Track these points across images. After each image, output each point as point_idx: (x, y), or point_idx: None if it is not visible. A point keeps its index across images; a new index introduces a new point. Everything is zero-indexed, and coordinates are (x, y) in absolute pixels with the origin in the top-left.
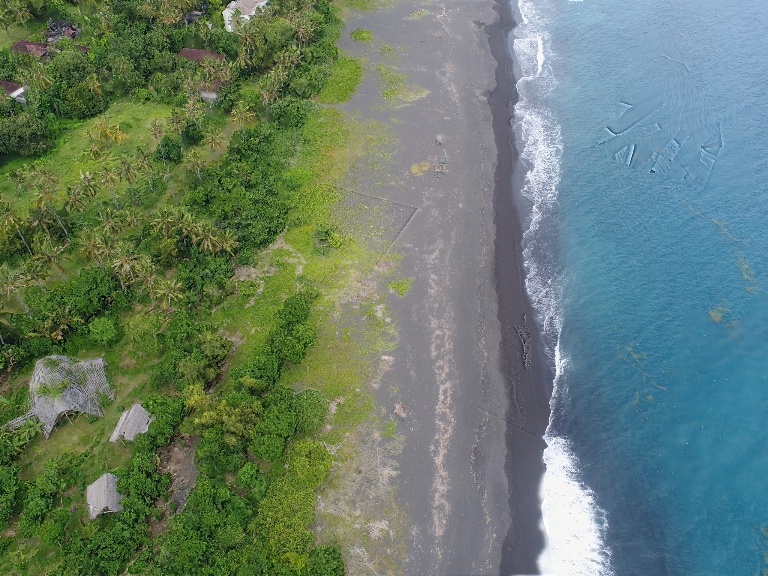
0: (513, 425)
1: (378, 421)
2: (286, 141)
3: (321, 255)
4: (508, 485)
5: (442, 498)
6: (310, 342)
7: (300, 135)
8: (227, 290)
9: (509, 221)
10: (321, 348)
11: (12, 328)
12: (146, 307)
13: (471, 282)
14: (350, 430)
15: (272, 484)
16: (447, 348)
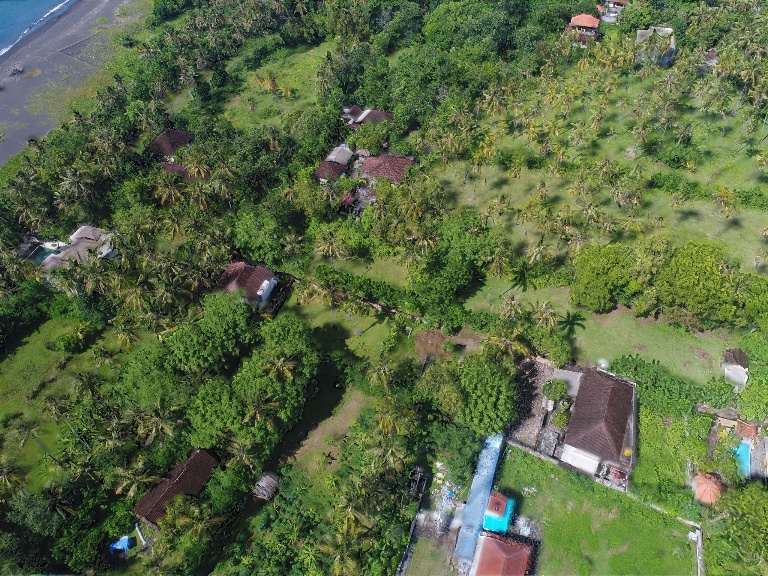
0: None
1: None
2: None
3: None
4: None
5: None
6: None
7: None
8: None
9: (5, 56)
10: None
11: None
12: None
13: None
14: None
15: None
16: (96, 8)
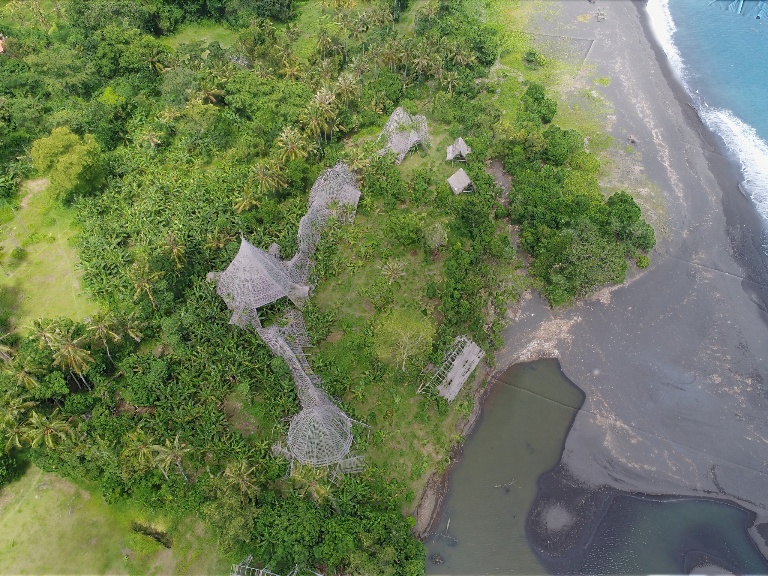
0: (706, 150)
1: (620, 145)
2: (473, 6)
3: (532, 70)
4: (714, 176)
5: (675, 181)
6: (555, 109)
7: (481, 2)
8: (480, 87)
9: (661, 48)
10: (561, 114)
11: (352, 104)
12: (422, 102)
13: (649, 80)
14: (603, 151)
15: (566, 174)
16: (648, 112)
